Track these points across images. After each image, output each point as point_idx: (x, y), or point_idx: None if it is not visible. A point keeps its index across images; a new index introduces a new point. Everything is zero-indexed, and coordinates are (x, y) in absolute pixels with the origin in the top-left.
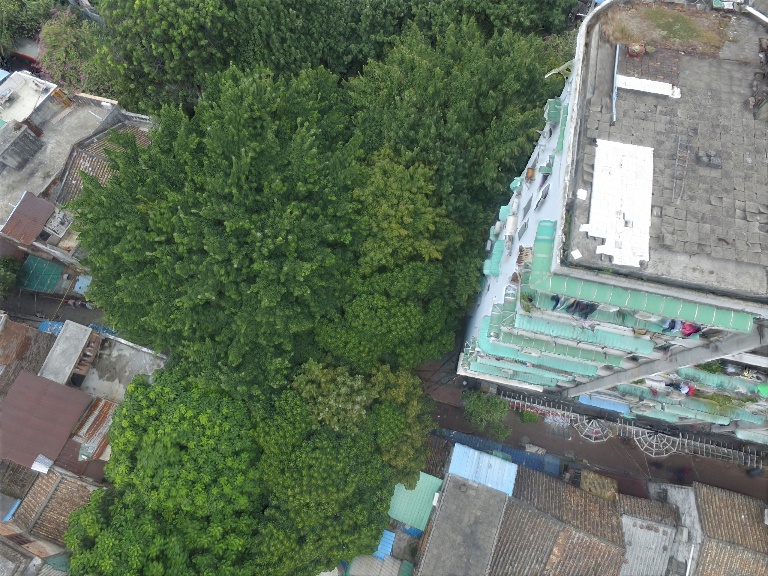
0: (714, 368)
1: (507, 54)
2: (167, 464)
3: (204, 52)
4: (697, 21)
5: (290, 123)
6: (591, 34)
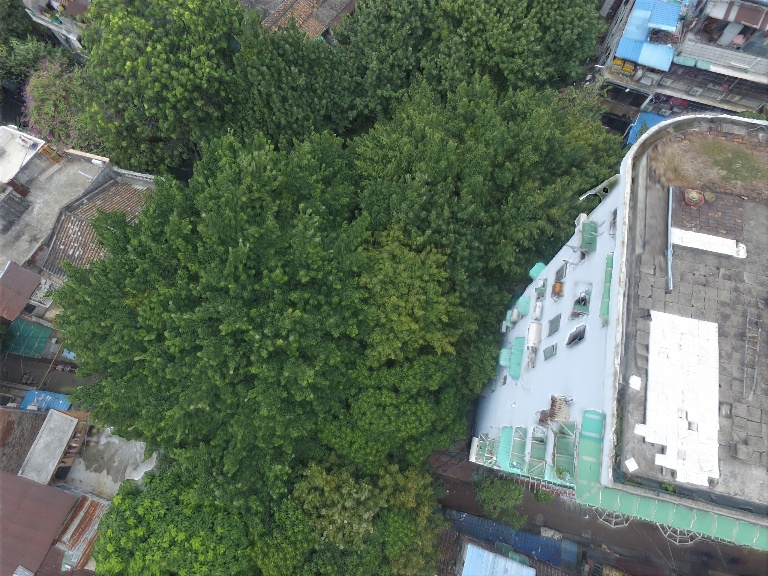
0: None
1: (523, 115)
2: None
3: (200, 112)
4: (761, 157)
5: (291, 198)
6: (637, 167)
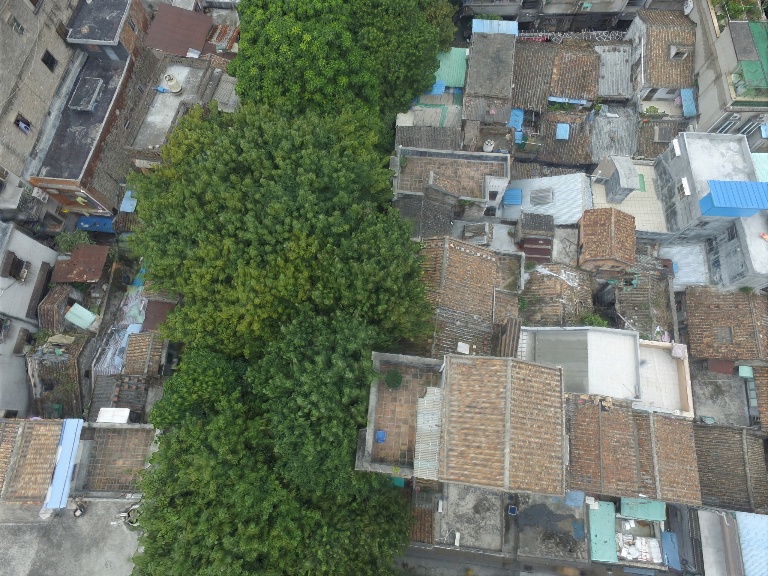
0: None
1: None
2: None
3: None
4: None
5: None
6: None
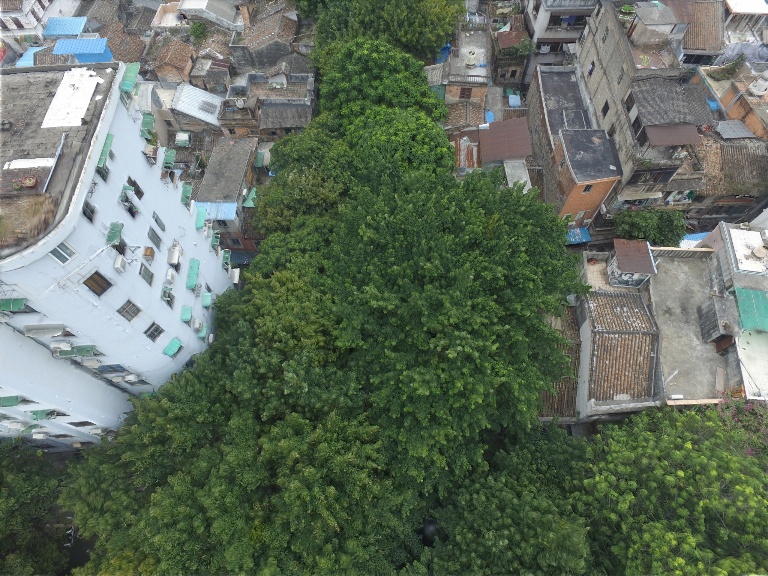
0: None
1: None
2: None
3: None
4: None
5: (423, 357)
6: None
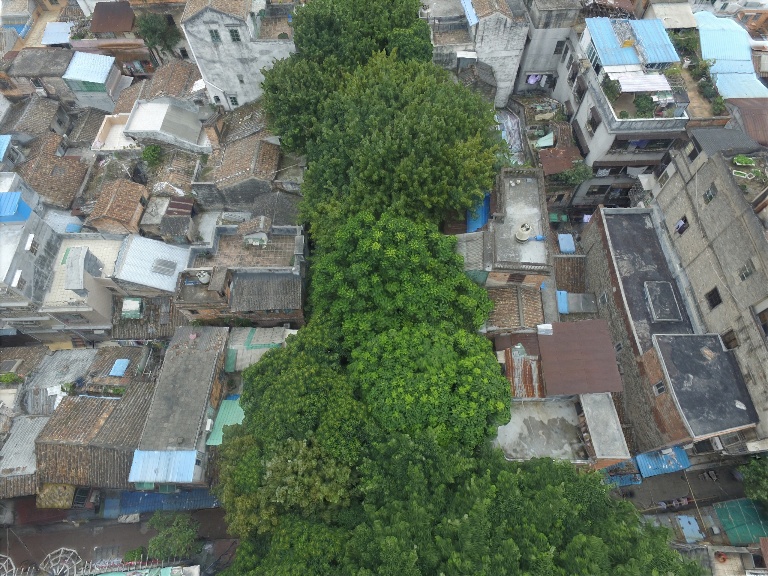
0: None
1: None
2: (424, 354)
3: None
4: None
5: None
6: None
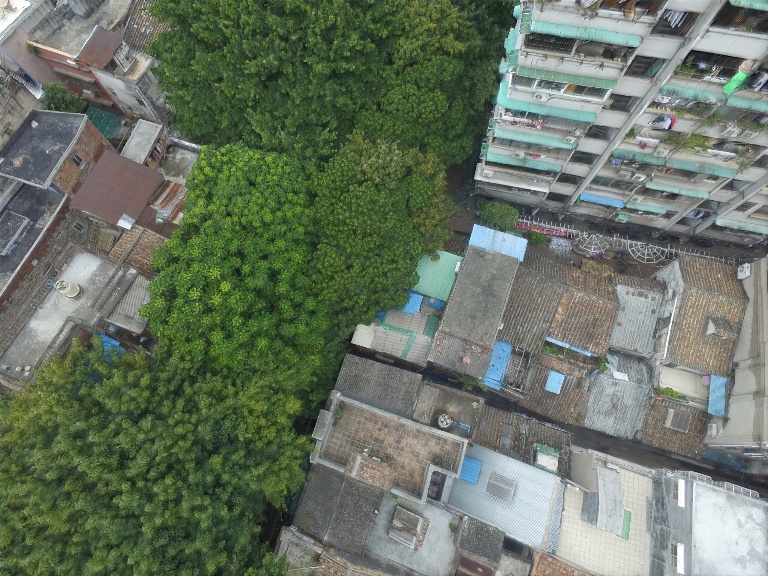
0: (689, 69)
1: None
2: (239, 195)
3: None
4: None
5: None
6: None
